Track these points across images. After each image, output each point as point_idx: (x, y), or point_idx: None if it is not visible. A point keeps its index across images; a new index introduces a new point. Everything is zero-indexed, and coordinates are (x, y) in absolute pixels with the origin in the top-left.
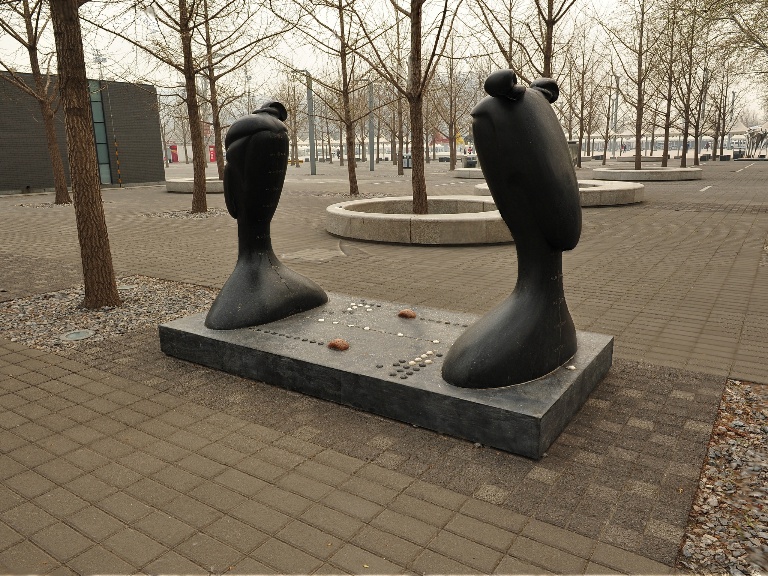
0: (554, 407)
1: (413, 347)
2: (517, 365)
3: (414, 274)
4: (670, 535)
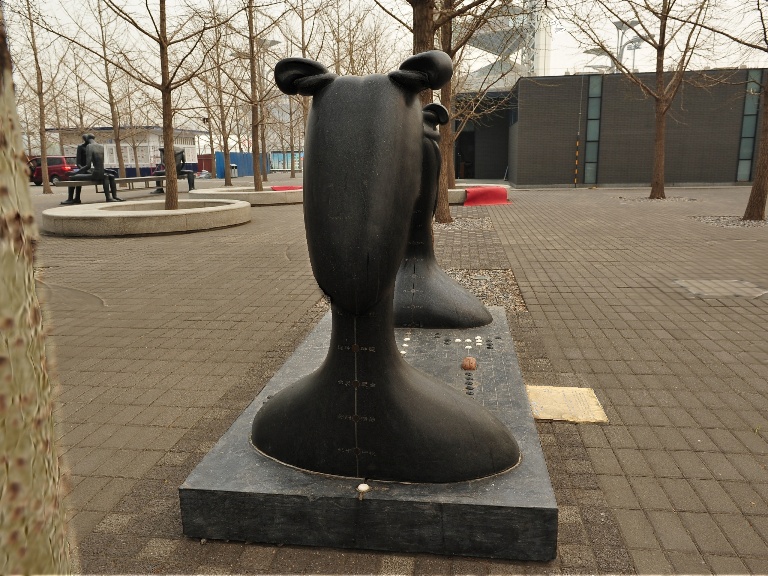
0: (230, 496)
1: None
2: (278, 436)
3: (764, 343)
4: None
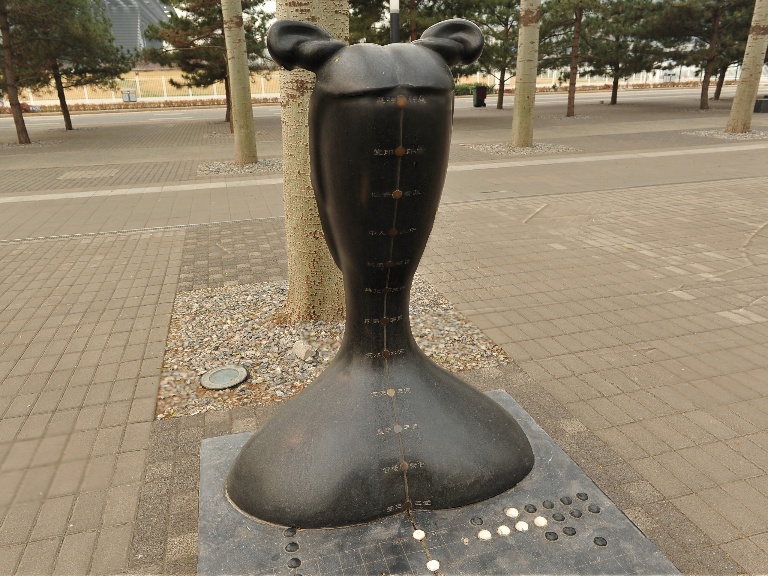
0: None
1: (493, 571)
2: None
3: None
4: (491, 370)
